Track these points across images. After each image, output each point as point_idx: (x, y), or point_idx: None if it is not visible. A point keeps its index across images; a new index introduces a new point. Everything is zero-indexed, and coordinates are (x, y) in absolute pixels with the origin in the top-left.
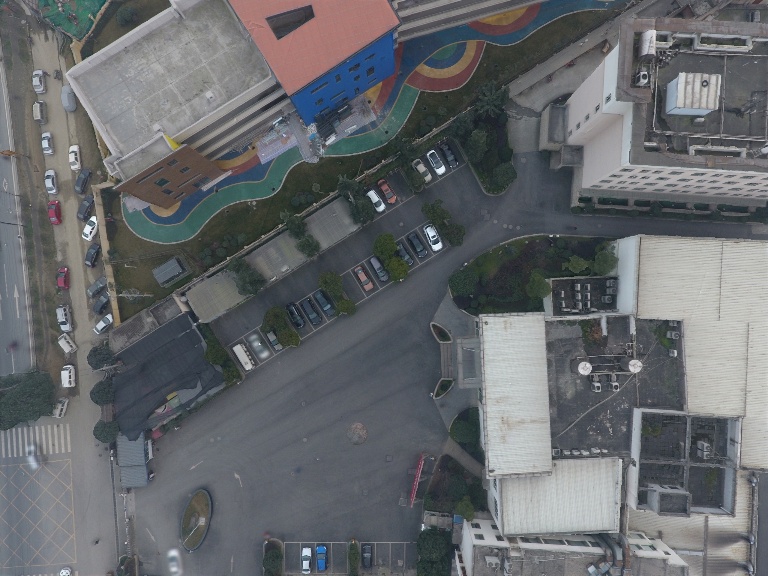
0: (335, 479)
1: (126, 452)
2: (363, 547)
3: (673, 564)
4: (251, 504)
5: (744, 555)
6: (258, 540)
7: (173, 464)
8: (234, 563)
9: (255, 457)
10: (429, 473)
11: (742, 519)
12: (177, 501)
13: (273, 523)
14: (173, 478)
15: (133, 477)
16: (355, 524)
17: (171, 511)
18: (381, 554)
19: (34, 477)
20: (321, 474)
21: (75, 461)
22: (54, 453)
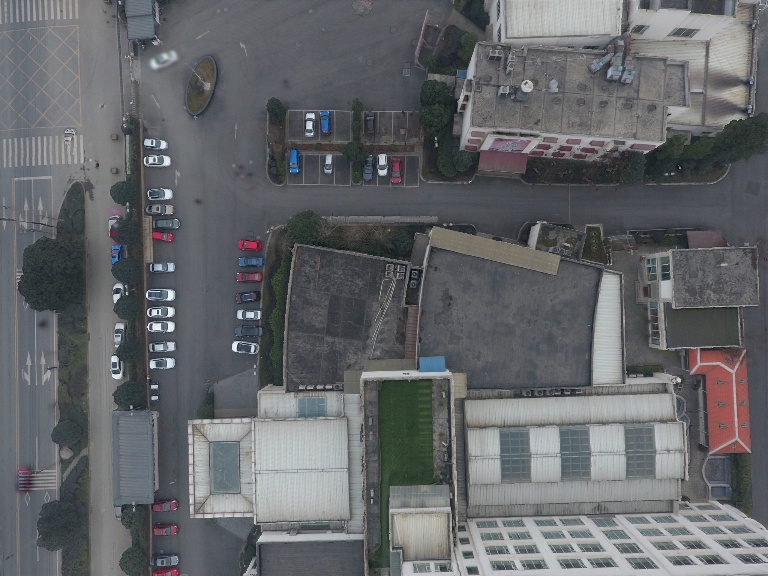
0: (340, 49)
1: (134, 2)
2: (366, 113)
3: (673, 59)
4: (256, 73)
5: (743, 99)
6: (262, 108)
7: (179, 34)
8: (238, 130)
9: (261, 28)
10: (433, 45)
11: (742, 64)
12: (183, 69)
13: (277, 92)
14: (179, 47)
15: (140, 28)
16: (359, 93)
17: (176, 79)
18: (384, 123)
19: (41, 41)
20: (326, 44)
21: (82, 27)
22: (62, 19)
